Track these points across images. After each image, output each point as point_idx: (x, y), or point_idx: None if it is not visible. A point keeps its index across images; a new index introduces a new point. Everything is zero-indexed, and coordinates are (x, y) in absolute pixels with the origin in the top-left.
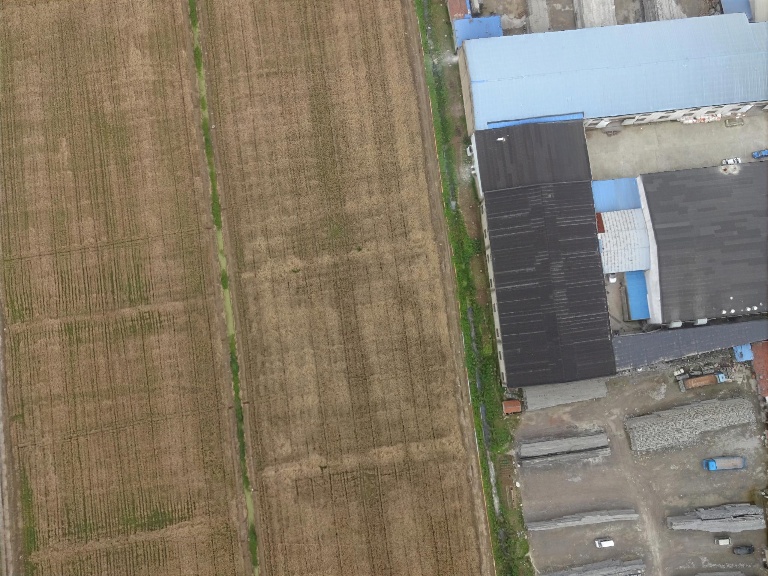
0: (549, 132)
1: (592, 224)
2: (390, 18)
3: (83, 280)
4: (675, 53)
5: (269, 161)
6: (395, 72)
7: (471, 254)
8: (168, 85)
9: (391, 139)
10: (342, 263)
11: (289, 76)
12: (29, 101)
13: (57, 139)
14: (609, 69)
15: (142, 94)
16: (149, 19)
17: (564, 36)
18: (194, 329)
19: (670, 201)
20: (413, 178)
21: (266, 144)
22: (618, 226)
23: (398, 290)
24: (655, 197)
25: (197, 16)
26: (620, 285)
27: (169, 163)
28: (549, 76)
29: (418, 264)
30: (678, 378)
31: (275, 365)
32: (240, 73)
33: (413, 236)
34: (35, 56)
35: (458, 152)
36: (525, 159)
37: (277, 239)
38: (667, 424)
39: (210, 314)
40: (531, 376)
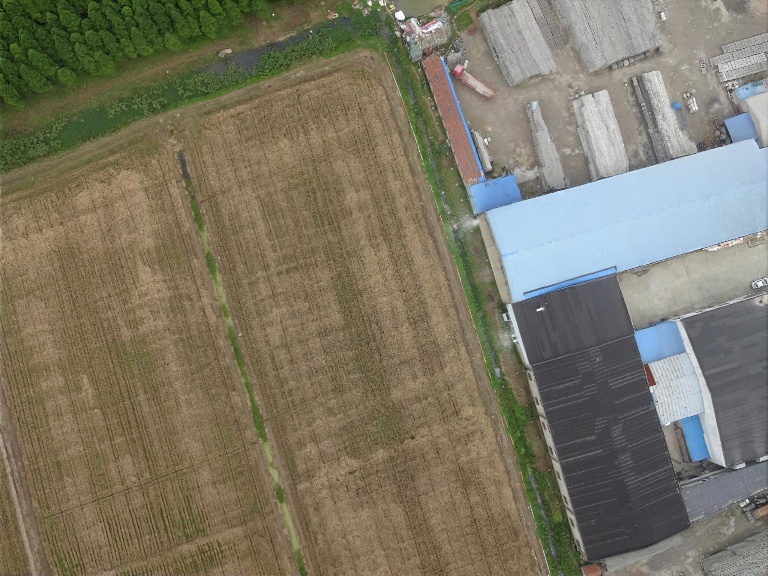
0: (586, 293)
1: (642, 379)
2: (403, 190)
3: (132, 523)
4: (695, 192)
5: (305, 362)
6: (417, 246)
7: (525, 422)
8: (185, 299)
9: (425, 317)
10: (398, 455)
11: (310, 268)
12: (39, 341)
13: (77, 377)
14: (634, 220)
15: (160, 313)
16: (153, 232)
17: (584, 191)
18: (258, 553)
19: (714, 344)
20: (454, 354)
21: (299, 344)
22: (667, 376)
23: (459, 473)
24: (699, 342)
25: (202, 219)
26: (674, 426)
27: (201, 382)
28: (577, 237)
29: (474, 442)
30: (745, 510)
31: (348, 574)
32: (259, 274)
33: (464, 414)
34: (37, 292)
35: (494, 318)
36: (567, 326)
37: (327, 442)
38: (743, 560)
39: (272, 533)
40: (610, 546)
